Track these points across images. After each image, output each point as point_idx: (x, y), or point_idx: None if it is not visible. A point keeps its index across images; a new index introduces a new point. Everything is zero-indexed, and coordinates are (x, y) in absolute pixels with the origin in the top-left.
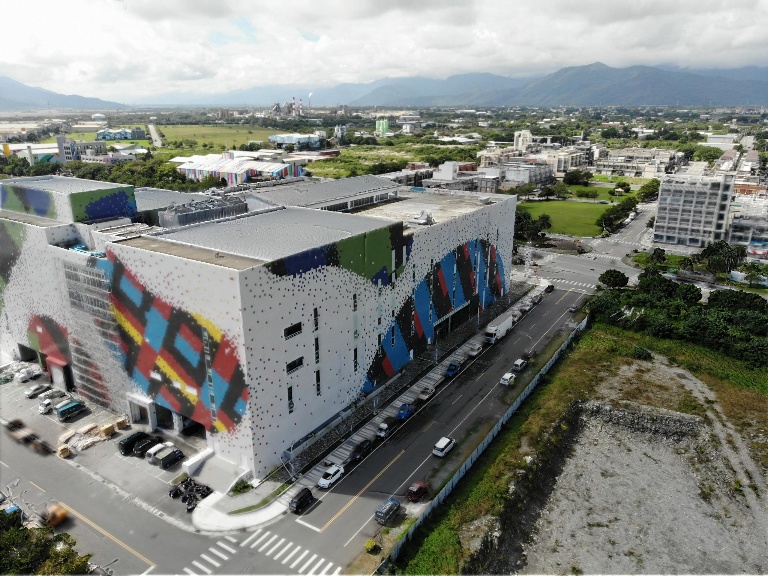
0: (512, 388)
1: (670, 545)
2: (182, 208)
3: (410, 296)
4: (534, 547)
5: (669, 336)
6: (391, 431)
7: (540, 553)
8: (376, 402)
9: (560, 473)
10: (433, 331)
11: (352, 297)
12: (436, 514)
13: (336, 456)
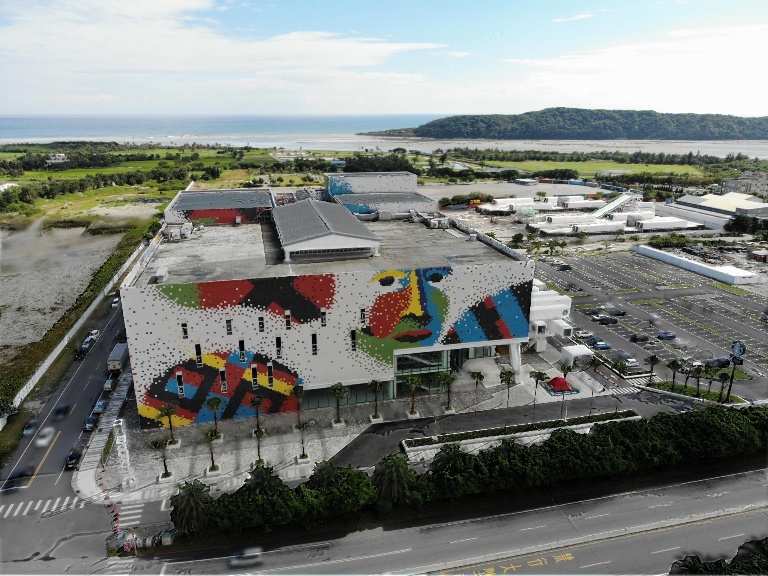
0: None
1: None
2: None
3: None
4: None
5: None
6: None
7: None
8: None
9: None
10: None
11: None
12: None
13: None
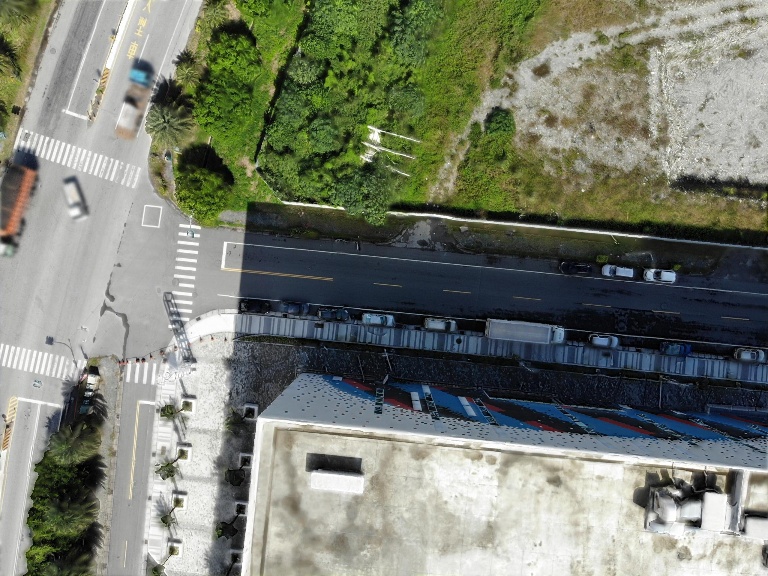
0: None
1: None
2: None
3: None
4: None
5: None
6: None
7: None
8: None
9: None
10: None
11: None
12: None
13: None
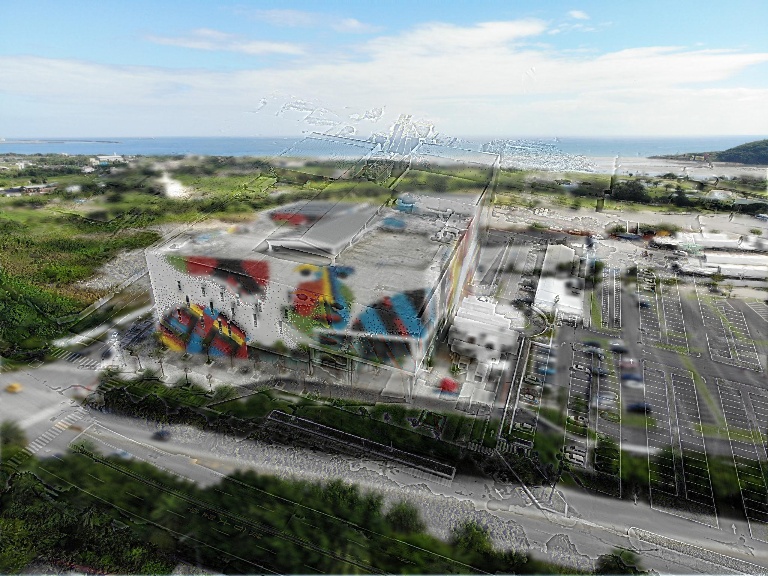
0: None
1: None
2: (381, 159)
3: None
4: None
5: None
6: None
7: None
8: None
9: None
10: None
11: None
12: None
13: None
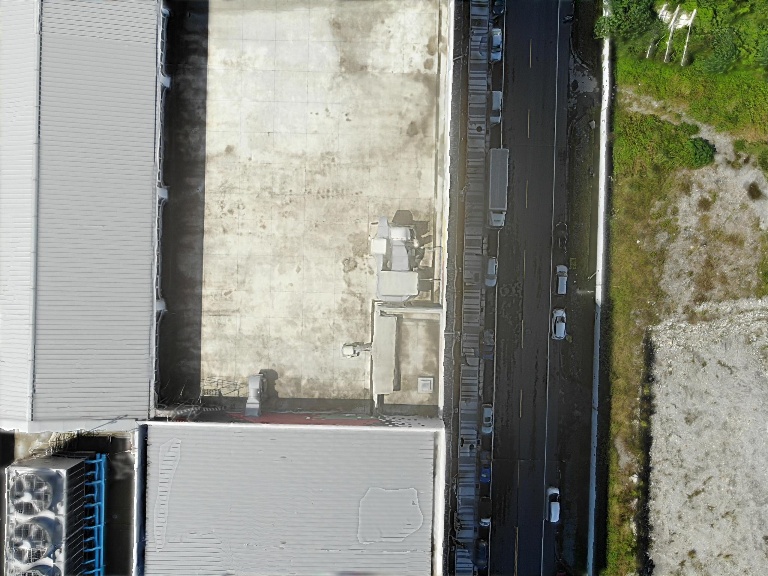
0: (570, 343)
1: (754, 488)
2: None
3: None
4: (655, 548)
5: None
6: None
7: (661, 551)
8: None
9: (651, 444)
10: None
11: None
12: None
13: (462, 571)
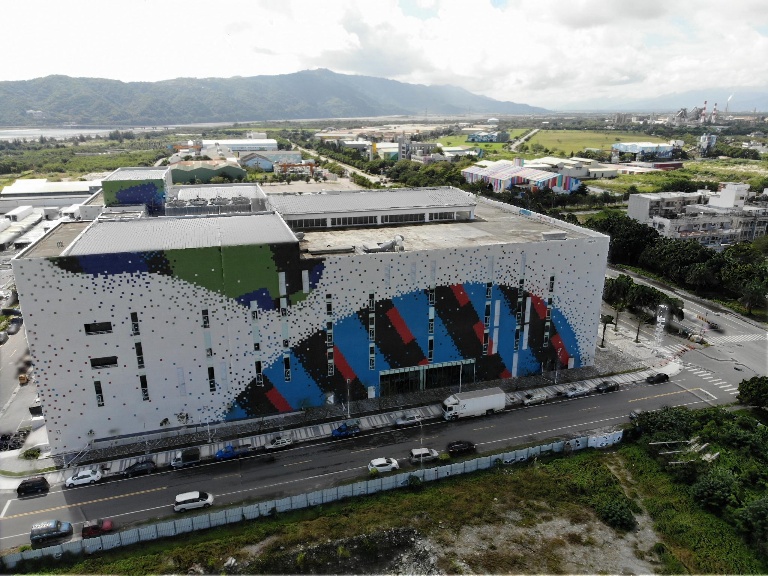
0: (369, 478)
1: None
2: (175, 202)
3: (322, 330)
4: None
5: (718, 511)
6: (189, 464)
7: None
8: (229, 431)
9: None
10: (380, 380)
11: (200, 312)
12: (64, 559)
13: (122, 464)
